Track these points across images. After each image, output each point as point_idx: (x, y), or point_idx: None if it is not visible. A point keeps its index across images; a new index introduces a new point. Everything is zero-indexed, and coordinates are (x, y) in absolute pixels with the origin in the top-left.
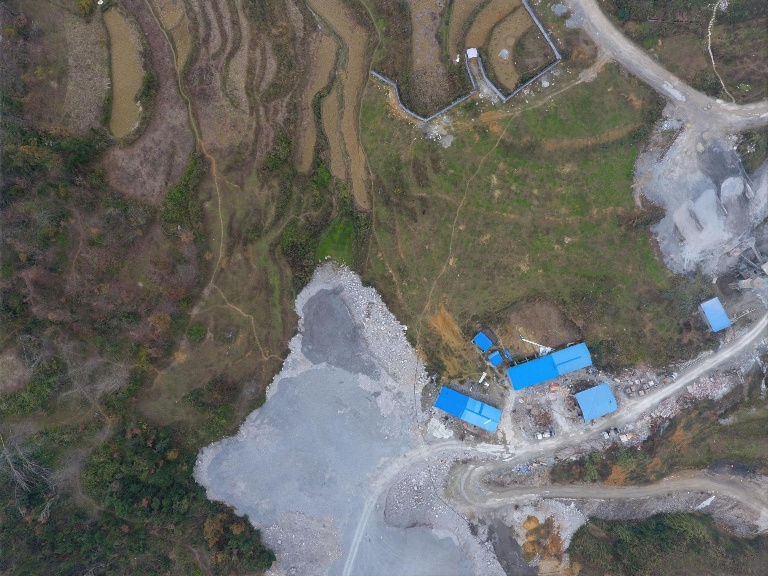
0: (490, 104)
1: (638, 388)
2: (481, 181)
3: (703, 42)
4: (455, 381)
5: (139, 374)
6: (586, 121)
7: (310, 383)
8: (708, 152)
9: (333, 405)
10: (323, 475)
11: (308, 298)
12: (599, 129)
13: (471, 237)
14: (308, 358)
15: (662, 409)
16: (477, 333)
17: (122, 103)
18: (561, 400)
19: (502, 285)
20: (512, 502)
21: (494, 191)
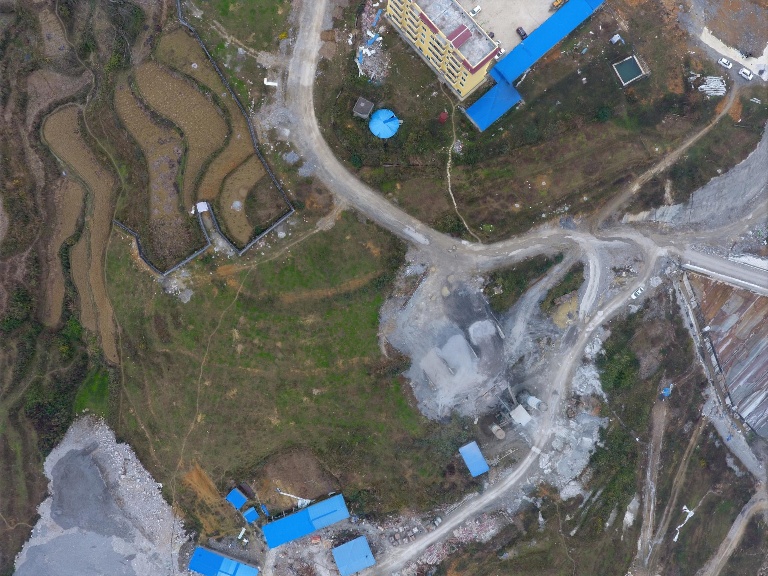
0: (225, 258)
1: (403, 535)
2: (222, 336)
3: (444, 183)
4: (212, 539)
5: None
6: (324, 272)
7: (61, 550)
8: (453, 296)
9: (85, 571)
10: None
11: (57, 460)
12: (338, 279)
13: (218, 392)
14: (58, 523)
15: (428, 556)
16: (231, 489)
17: None
18: (324, 552)
19: (254, 439)
20: None
21: (237, 346)
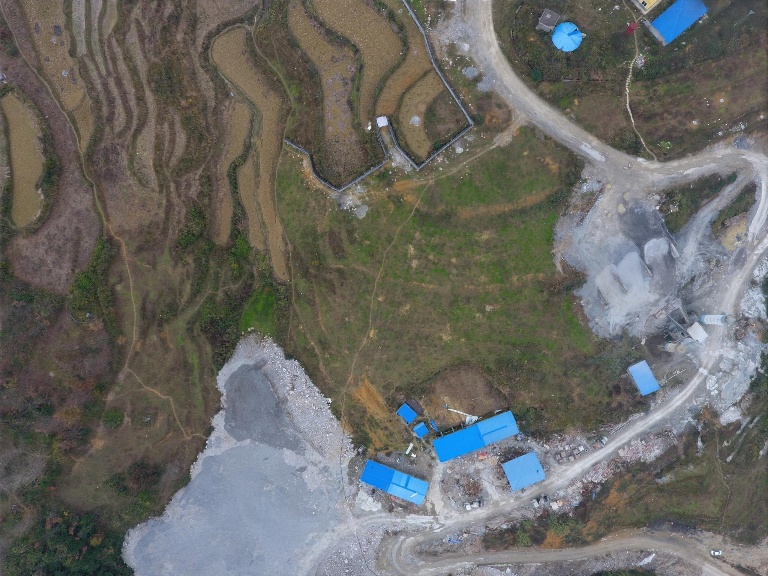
0: (403, 173)
1: (568, 453)
2: (398, 251)
3: (621, 99)
4: (381, 453)
5: (55, 464)
6: (502, 187)
7: (234, 460)
8: (630, 213)
9: (258, 482)
10: (251, 553)
11: (230, 374)
12: (516, 195)
13: (391, 308)
14: (232, 435)
15: (593, 474)
16: (401, 405)
17: (23, 191)
18: (490, 468)
19: (425, 355)
20: (445, 571)
21: (411, 261)
